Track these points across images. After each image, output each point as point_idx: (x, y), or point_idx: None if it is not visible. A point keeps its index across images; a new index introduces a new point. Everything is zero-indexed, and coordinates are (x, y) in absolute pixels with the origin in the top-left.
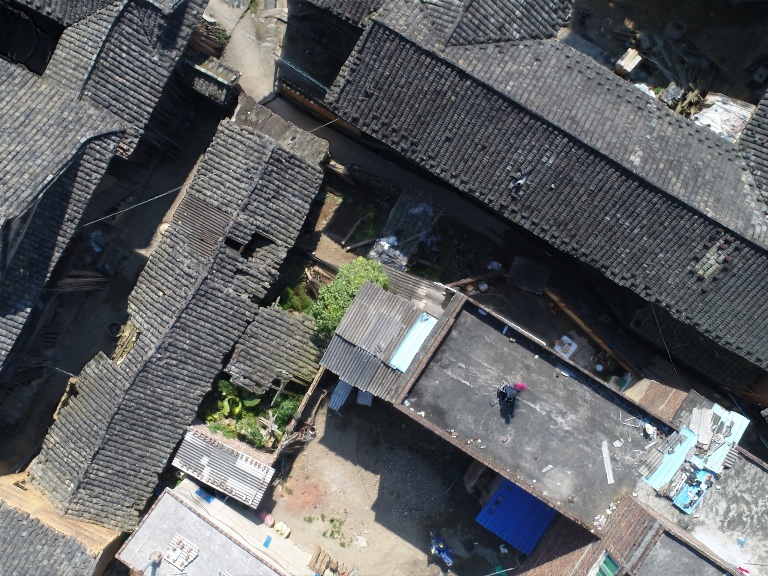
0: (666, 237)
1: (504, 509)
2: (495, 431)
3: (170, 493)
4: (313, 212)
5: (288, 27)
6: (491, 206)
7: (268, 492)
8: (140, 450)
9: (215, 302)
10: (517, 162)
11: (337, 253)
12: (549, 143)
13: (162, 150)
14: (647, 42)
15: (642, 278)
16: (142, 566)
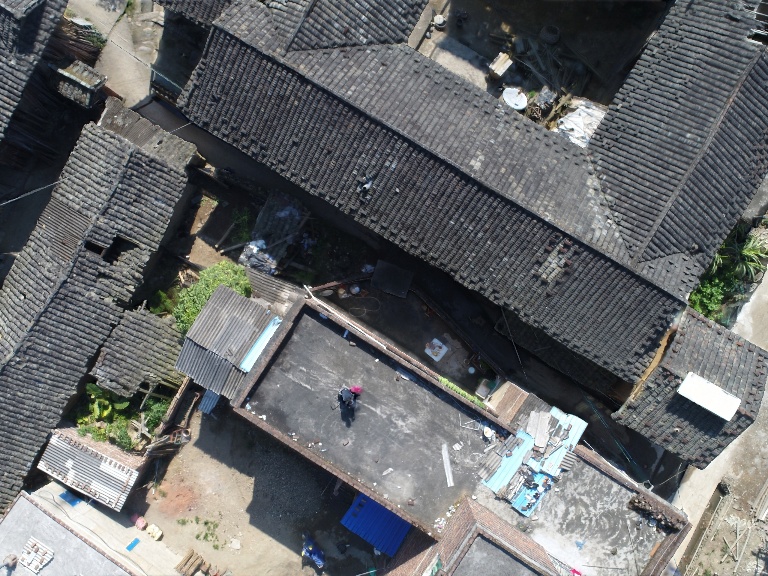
0: (509, 241)
1: (367, 511)
2: (336, 434)
3: (25, 496)
4: (189, 215)
5: (165, 31)
6: (341, 210)
7: (141, 495)
8: (2, 453)
9: (76, 306)
10: (362, 166)
11: (211, 256)
12: (390, 148)
13: (34, 153)
14: (521, 46)
15: (489, 282)
16: None
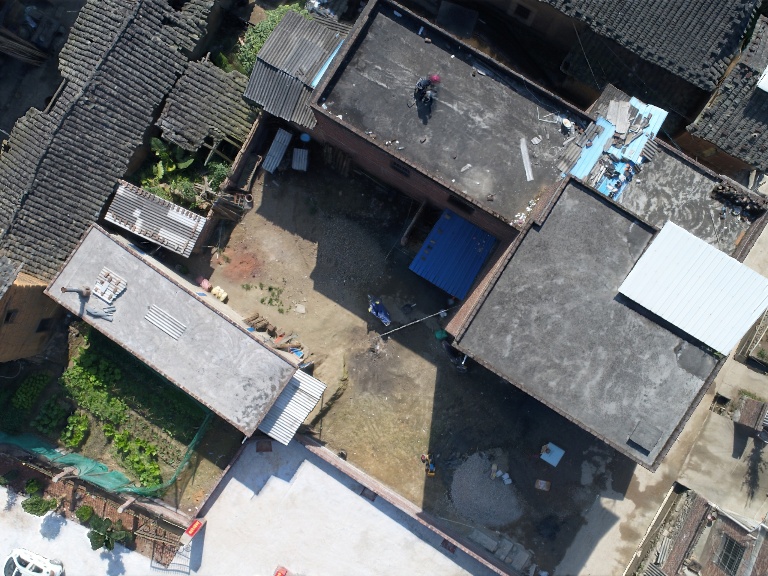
0: None
1: (437, 253)
2: (413, 132)
3: (97, 227)
4: None
5: None
6: None
7: (205, 259)
8: (71, 200)
9: (143, 49)
10: None
11: None
12: None
13: None
14: None
15: None
16: (71, 301)
